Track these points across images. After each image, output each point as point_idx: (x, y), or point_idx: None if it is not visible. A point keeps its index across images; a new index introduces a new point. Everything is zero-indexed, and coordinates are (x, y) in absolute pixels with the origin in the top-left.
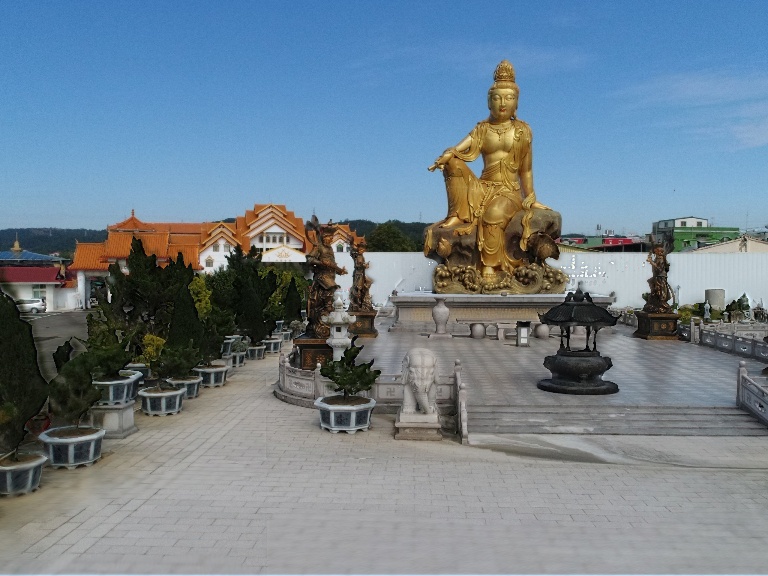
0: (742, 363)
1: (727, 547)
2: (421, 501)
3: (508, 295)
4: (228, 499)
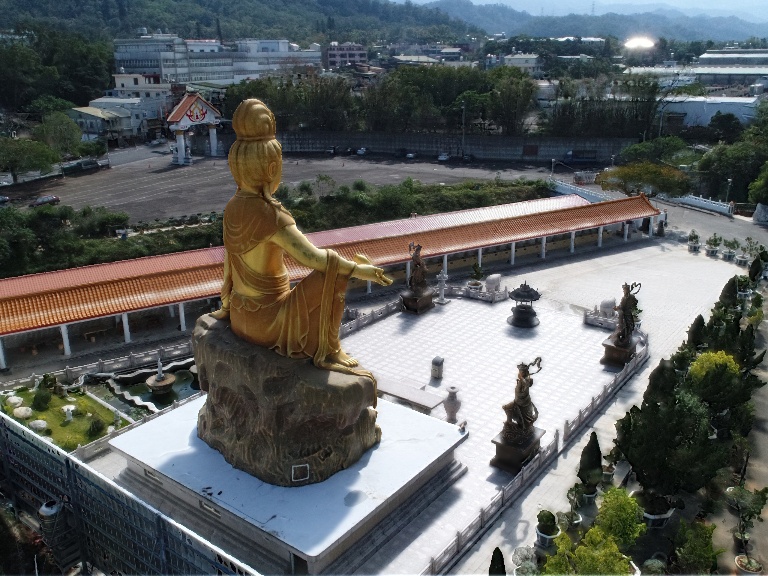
0: None
1: (587, 287)
2: None
3: None
4: None
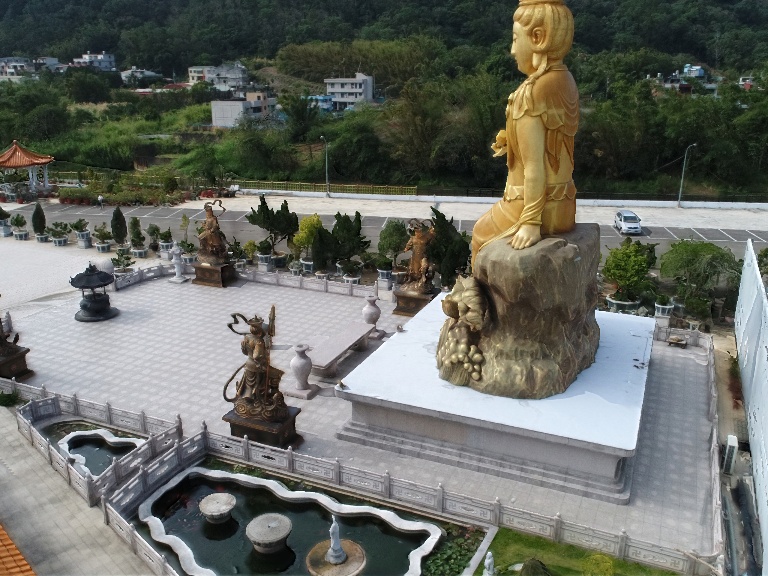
0: (8, 311)
1: None
2: (48, 278)
3: (423, 338)
4: (83, 265)
